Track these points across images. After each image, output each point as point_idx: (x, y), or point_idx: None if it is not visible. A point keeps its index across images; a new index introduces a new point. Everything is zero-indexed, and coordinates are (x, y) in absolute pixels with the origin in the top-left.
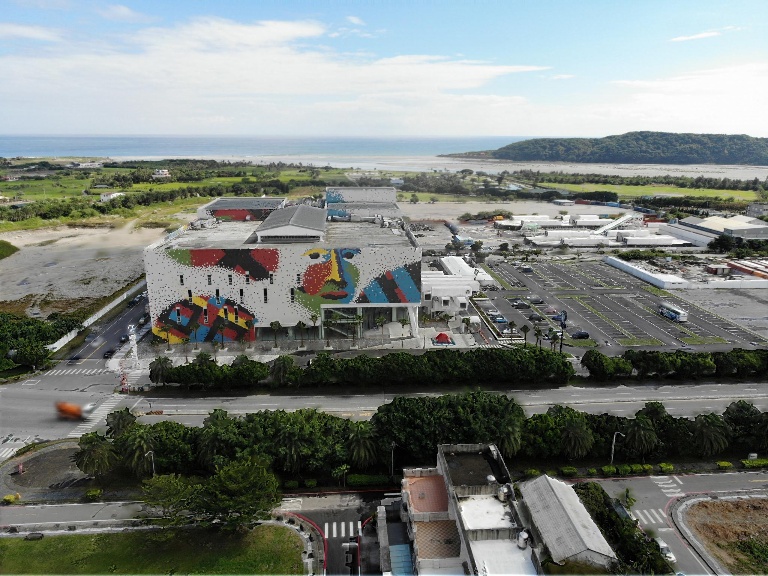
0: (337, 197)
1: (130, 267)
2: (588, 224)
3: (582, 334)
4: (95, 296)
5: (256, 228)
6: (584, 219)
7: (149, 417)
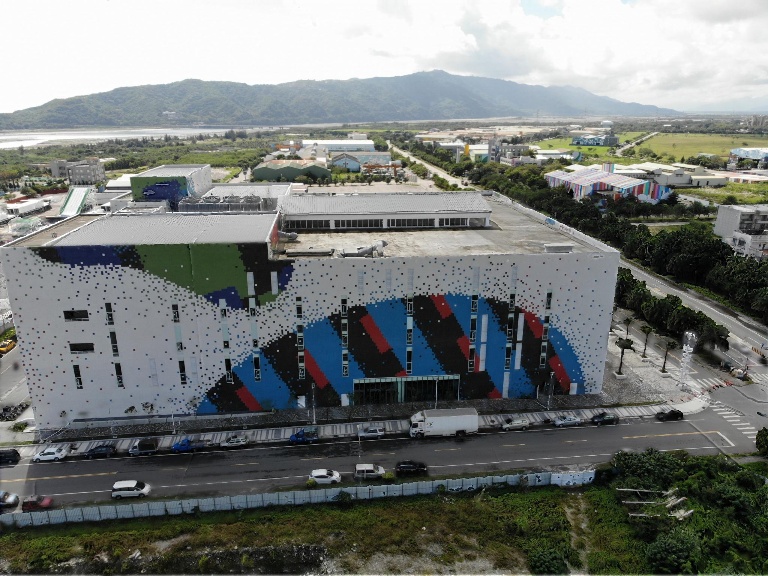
0: None
1: None
2: (27, 210)
3: None
4: None
5: (374, 232)
6: None
7: (767, 354)
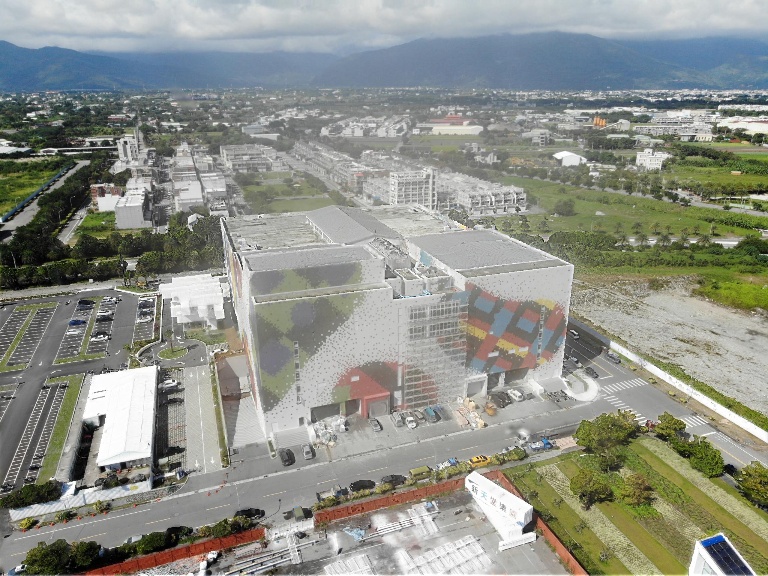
0: None
1: (761, 393)
2: None
3: (86, 300)
4: (606, 320)
5: None
6: None
7: None
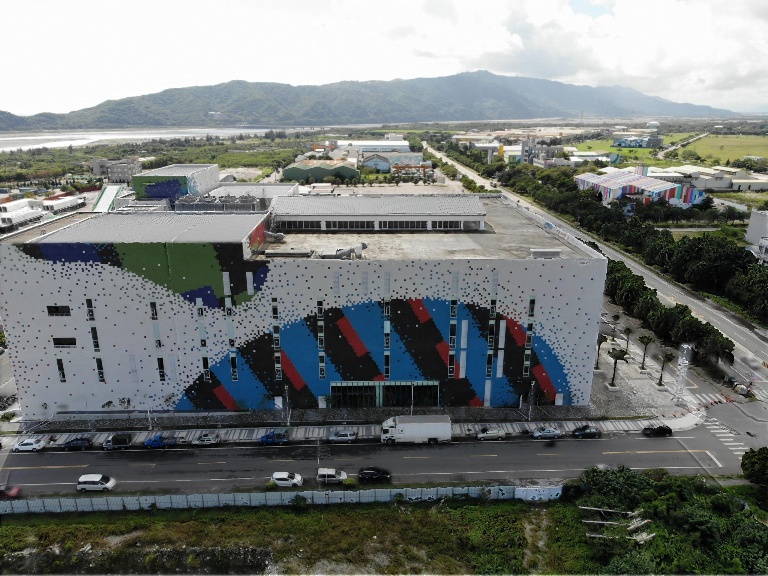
0: (194, 187)
1: None
2: (62, 207)
3: None
4: None
5: (363, 234)
6: (53, 202)
7: None
